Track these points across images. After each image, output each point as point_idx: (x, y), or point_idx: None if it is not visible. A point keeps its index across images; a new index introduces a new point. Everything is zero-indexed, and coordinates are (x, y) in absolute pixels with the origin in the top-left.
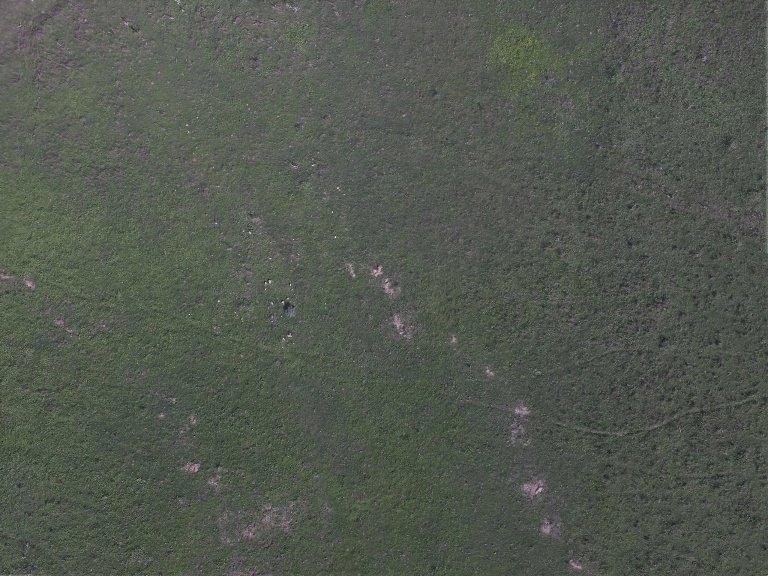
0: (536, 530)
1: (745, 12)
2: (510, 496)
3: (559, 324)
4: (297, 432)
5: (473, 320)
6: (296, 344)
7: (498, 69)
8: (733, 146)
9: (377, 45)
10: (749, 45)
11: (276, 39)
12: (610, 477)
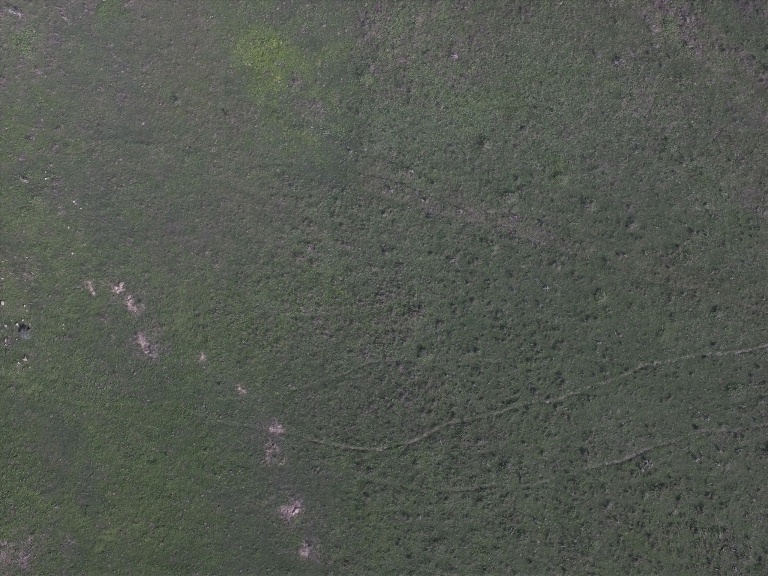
0: (294, 553)
1: (497, 8)
2: (266, 519)
3: (313, 337)
4: (34, 461)
5: (223, 336)
6: (33, 368)
7: (242, 73)
8: (487, 146)
9: (111, 51)
10: (502, 42)
11: (0, 47)
12: (370, 494)
